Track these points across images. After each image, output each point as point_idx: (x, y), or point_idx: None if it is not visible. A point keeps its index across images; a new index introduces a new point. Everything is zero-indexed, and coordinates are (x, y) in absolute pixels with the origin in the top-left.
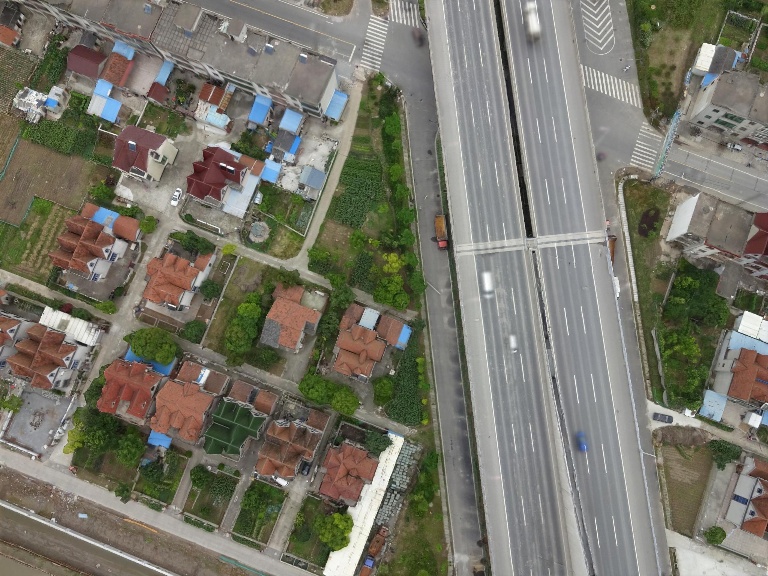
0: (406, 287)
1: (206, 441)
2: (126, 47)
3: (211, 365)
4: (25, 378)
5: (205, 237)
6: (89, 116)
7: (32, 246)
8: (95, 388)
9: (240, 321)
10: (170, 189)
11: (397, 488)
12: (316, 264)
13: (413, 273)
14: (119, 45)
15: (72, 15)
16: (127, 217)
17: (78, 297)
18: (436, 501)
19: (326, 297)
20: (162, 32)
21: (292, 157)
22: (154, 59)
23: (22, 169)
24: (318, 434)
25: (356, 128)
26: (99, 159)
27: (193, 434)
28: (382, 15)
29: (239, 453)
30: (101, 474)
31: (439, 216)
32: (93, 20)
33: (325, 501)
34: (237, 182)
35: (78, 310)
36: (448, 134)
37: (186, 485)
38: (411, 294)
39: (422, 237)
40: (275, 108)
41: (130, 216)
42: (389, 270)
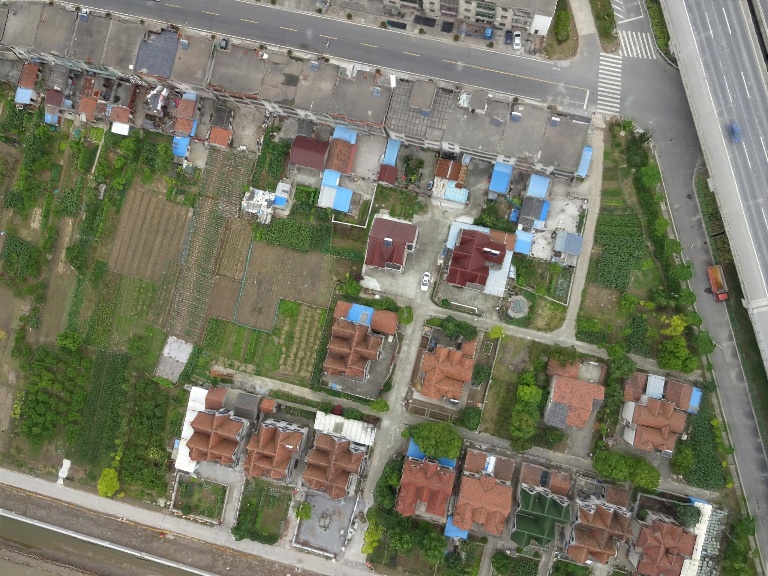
0: (690, 348)
1: (514, 533)
2: (347, 131)
3: (491, 450)
4: (318, 488)
5: (462, 319)
6: (321, 209)
7: (287, 350)
8: (385, 488)
9: (525, 407)
10: (417, 273)
11: (708, 555)
12: (584, 333)
13: (699, 334)
14: (340, 130)
15: (295, 109)
16: (382, 311)
17: (345, 397)
18: (749, 563)
19: (601, 367)
20: (395, 115)
21: (543, 224)
22: (374, 137)
23: (262, 272)
24: (630, 515)
25: (603, 181)
26: (339, 252)
27: (501, 529)
28: (613, 51)
29: (550, 542)
30: (398, 567)
31: (713, 266)
32: (320, 112)
33: (633, 574)
34: (498, 263)
35: (350, 411)
36: (722, 180)
37: (486, 571)
38: (695, 354)
39: (694, 290)
40: (512, 172)
41: (385, 309)
42: (672, 333)
